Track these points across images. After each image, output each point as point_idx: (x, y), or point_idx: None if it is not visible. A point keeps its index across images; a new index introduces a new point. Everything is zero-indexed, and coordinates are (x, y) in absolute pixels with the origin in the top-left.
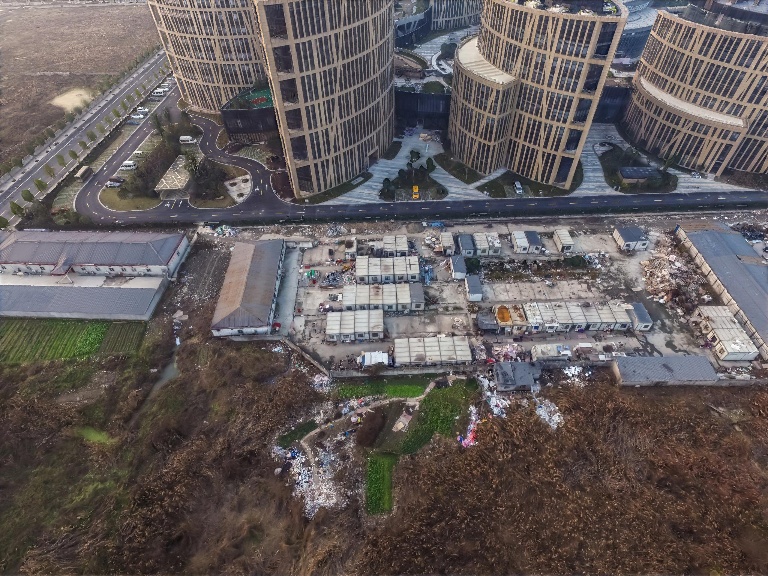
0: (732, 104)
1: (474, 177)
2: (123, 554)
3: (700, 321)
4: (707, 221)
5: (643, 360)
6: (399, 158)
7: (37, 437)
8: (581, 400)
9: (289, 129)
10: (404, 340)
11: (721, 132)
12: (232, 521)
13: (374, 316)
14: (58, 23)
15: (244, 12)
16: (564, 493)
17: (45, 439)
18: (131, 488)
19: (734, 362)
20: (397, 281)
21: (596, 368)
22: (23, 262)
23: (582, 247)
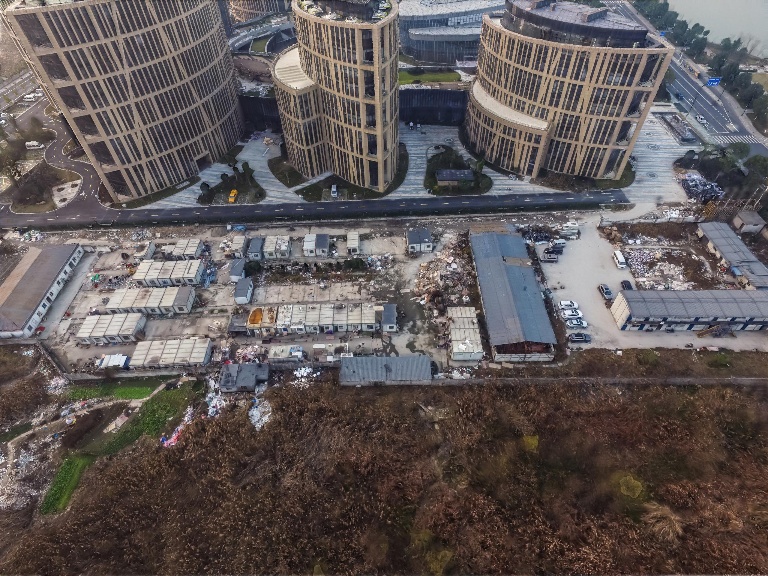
0: (537, 107)
1: (297, 181)
2: None
3: (444, 322)
4: (505, 223)
5: (367, 361)
6: None
7: None
8: (287, 400)
9: (89, 135)
10: (147, 343)
11: (526, 135)
12: None
13: (130, 319)
14: None
15: None
16: (224, 491)
17: None
18: None
19: (463, 362)
20: (176, 284)
21: (326, 369)
22: None
23: (372, 249)
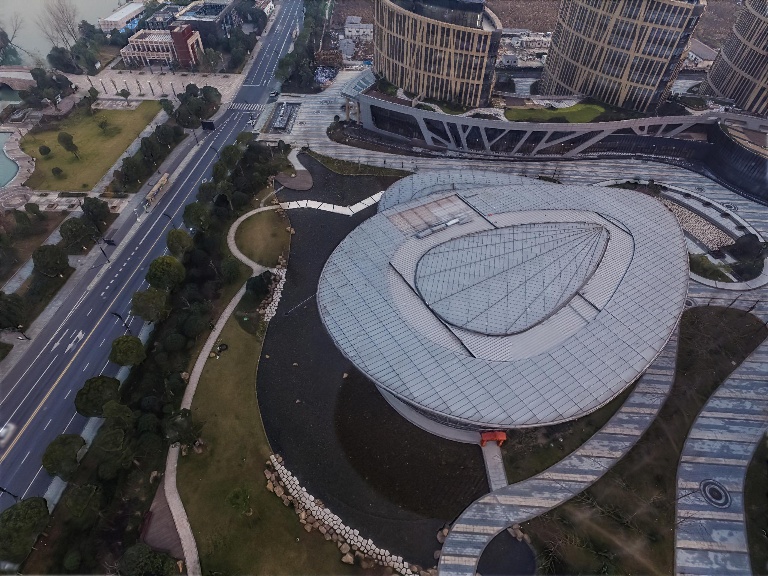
0: None
1: None
2: None
3: None
4: None
5: None
6: None
7: None
8: None
9: None
10: None
11: None
12: None
13: None
14: None
15: None
16: None
17: None
18: None
19: None
20: None
21: None
22: None
23: (535, 62)
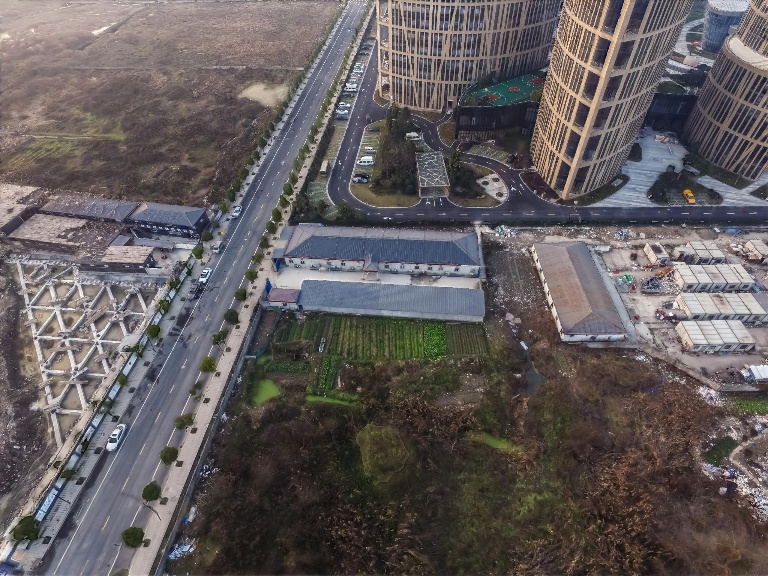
0: None
1: (743, 182)
2: (631, 575)
3: None
4: None
5: None
6: (647, 160)
7: (443, 441)
8: None
9: None
10: None
11: None
12: (704, 543)
13: (736, 327)
14: (202, 17)
15: (488, 7)
16: None
17: (454, 444)
18: (579, 502)
19: None
20: (725, 290)
21: None
22: (328, 257)
23: None
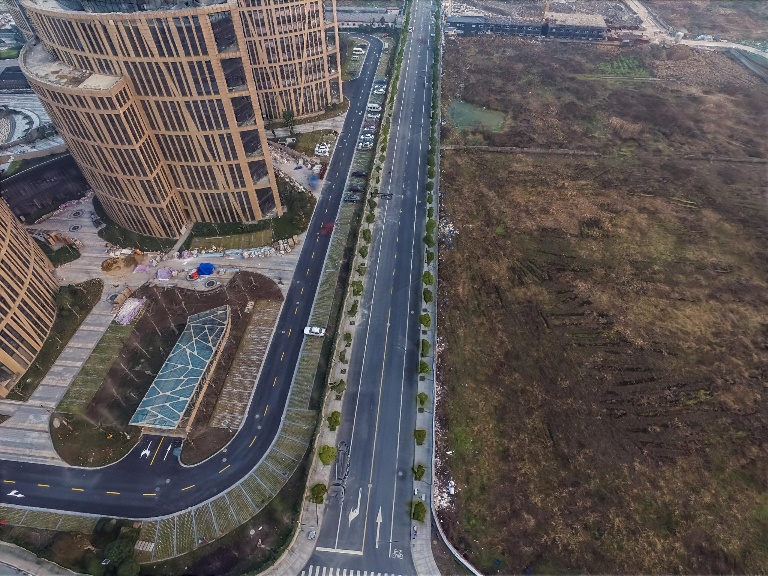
0: None
1: None
2: None
3: None
4: None
5: None
6: None
7: None
8: None
9: None
10: None
11: None
12: None
13: None
14: None
15: None
16: None
17: None
18: None
19: None
20: None
21: None
22: None
23: None
